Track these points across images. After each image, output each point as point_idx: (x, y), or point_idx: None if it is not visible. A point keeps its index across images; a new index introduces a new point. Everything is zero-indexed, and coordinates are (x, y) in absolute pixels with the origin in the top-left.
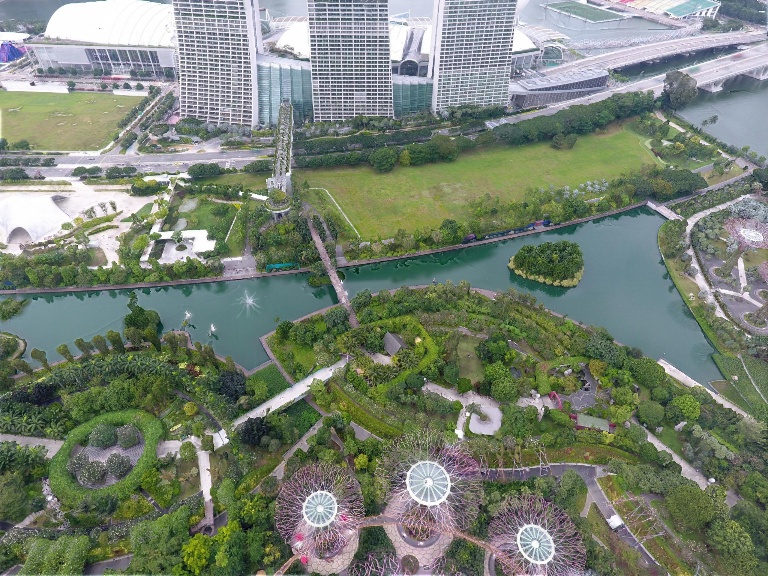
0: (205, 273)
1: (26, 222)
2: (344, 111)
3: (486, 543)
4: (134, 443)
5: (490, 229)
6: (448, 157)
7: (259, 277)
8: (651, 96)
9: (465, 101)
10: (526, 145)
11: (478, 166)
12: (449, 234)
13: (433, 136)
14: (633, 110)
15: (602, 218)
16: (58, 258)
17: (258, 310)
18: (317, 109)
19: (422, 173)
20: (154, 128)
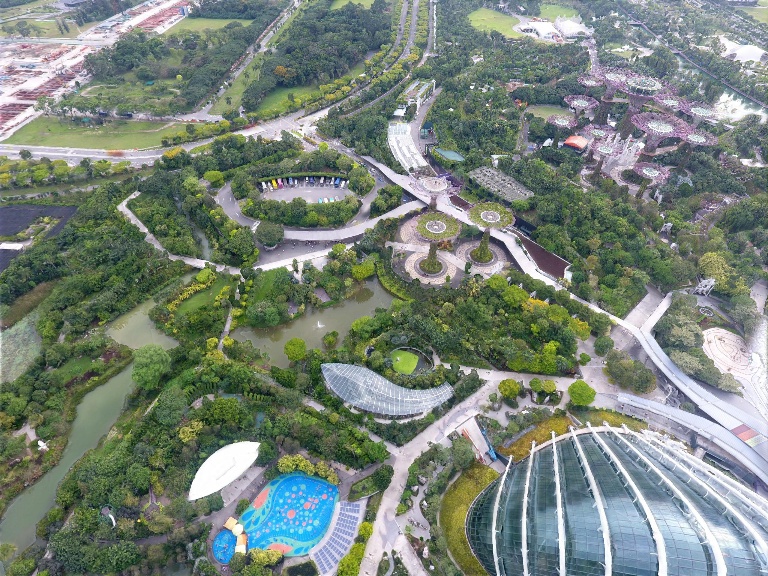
0: (764, 100)
1: (741, 53)
2: None
3: None
4: None
5: None
6: None
7: None
8: None
9: None
10: None
11: None
12: None
13: None
14: None
15: None
16: (728, 65)
17: None
18: None
19: None
20: None
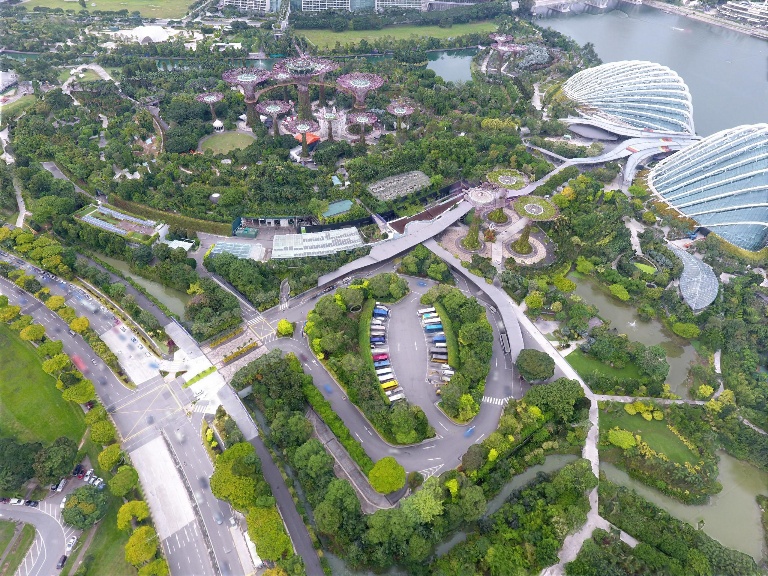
0: (240, 55)
1: (151, 35)
2: (320, 5)
3: (339, 85)
4: (214, 86)
5: (387, 50)
6: (376, 26)
7: (266, 59)
8: (510, 6)
9: (394, 4)
10: (425, 26)
11: (393, 32)
12: (362, 45)
13: (368, 15)
14: (497, 13)
15: (452, 53)
16: (170, 45)
17: (265, 66)
18: (304, 4)
19: (360, 33)
20: (210, 8)
